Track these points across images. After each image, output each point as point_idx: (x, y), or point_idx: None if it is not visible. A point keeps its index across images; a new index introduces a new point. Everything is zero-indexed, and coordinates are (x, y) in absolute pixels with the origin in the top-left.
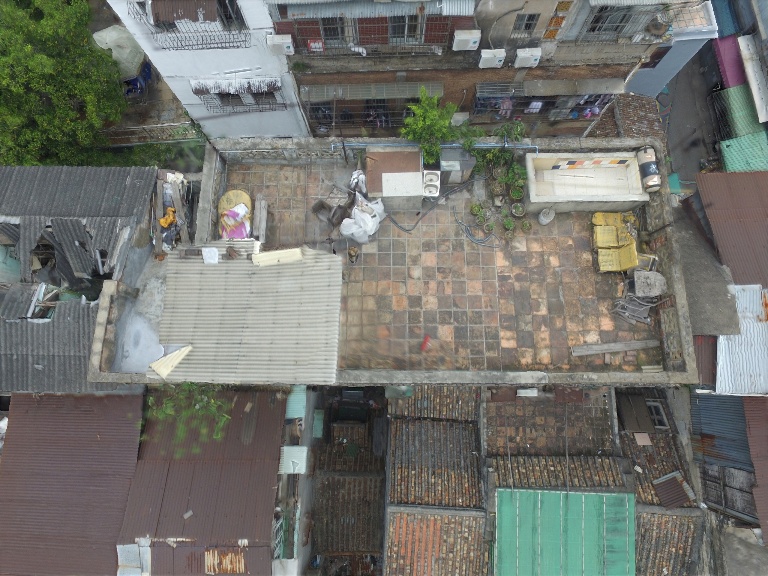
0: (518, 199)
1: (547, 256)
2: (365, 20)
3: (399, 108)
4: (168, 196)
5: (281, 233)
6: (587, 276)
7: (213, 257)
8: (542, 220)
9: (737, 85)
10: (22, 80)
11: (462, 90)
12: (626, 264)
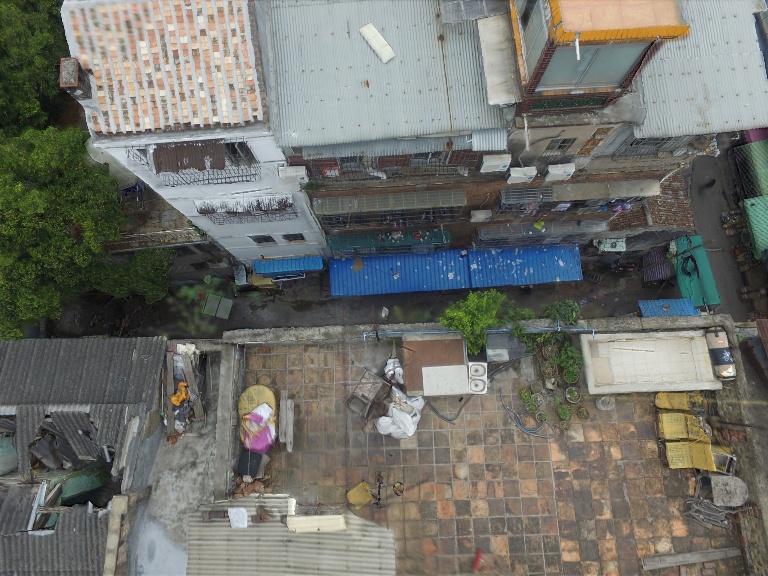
0: (573, 383)
1: (607, 447)
2: (388, 157)
3: (418, 212)
4: (179, 369)
5: (309, 428)
6: (653, 470)
7: (241, 520)
8: (601, 408)
9: (759, 140)
10: (13, 222)
11: (485, 193)
12: (700, 464)
